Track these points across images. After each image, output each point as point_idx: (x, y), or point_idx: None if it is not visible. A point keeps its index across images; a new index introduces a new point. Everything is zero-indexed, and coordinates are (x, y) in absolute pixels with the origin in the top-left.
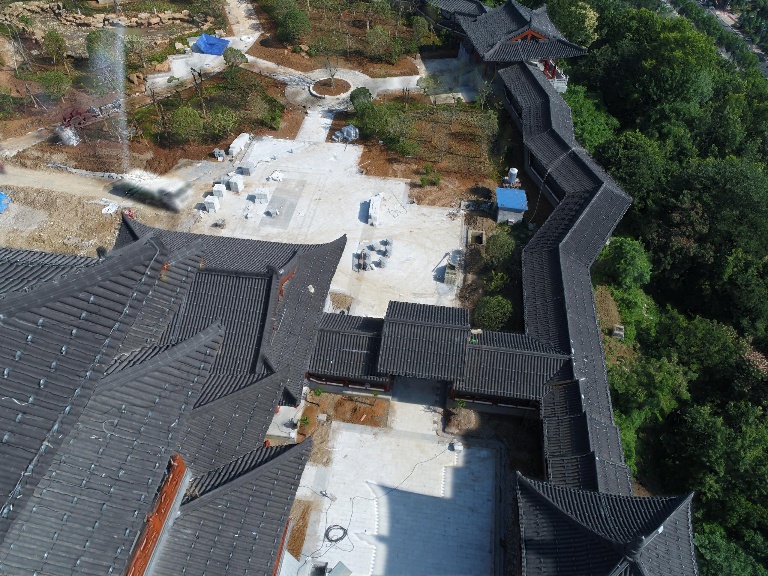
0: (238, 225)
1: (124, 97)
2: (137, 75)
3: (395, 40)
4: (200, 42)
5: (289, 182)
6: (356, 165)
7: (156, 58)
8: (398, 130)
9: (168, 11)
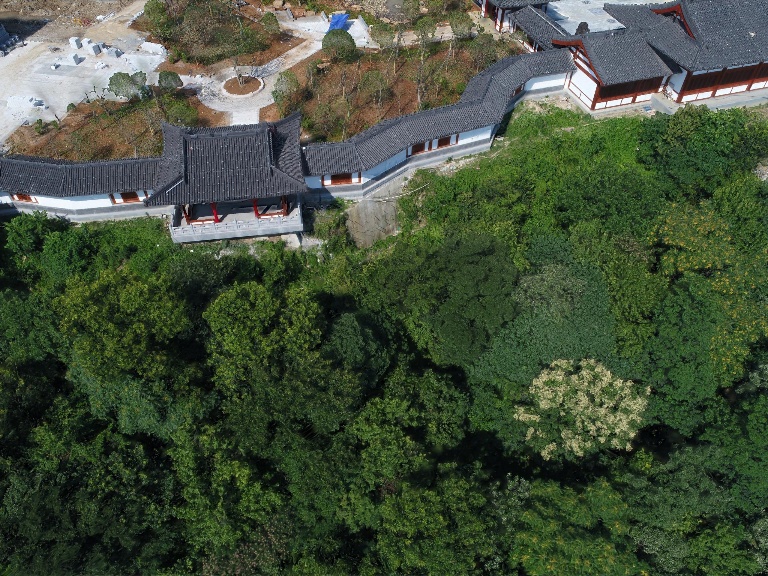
0: (52, 56)
1: (256, 6)
2: (285, 4)
3: (274, 91)
4: (337, 17)
5: (92, 71)
6: (97, 98)
7: (309, 5)
8: (101, 99)
9: (421, 2)
